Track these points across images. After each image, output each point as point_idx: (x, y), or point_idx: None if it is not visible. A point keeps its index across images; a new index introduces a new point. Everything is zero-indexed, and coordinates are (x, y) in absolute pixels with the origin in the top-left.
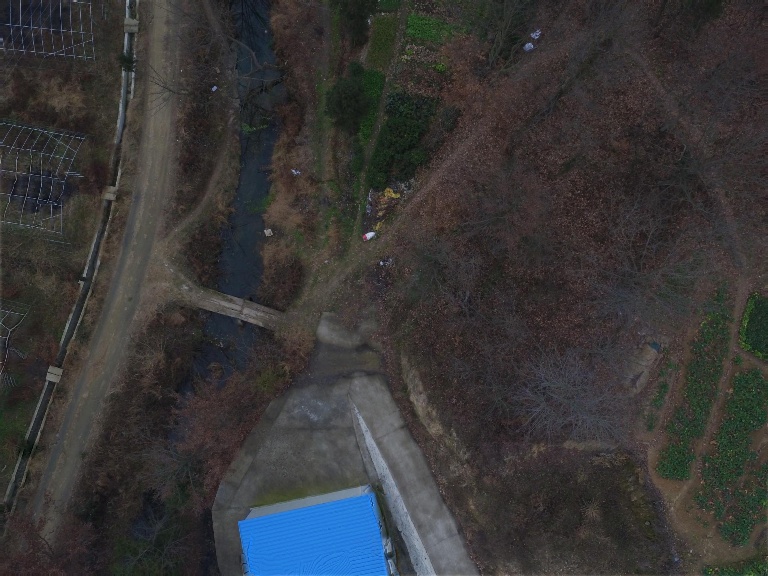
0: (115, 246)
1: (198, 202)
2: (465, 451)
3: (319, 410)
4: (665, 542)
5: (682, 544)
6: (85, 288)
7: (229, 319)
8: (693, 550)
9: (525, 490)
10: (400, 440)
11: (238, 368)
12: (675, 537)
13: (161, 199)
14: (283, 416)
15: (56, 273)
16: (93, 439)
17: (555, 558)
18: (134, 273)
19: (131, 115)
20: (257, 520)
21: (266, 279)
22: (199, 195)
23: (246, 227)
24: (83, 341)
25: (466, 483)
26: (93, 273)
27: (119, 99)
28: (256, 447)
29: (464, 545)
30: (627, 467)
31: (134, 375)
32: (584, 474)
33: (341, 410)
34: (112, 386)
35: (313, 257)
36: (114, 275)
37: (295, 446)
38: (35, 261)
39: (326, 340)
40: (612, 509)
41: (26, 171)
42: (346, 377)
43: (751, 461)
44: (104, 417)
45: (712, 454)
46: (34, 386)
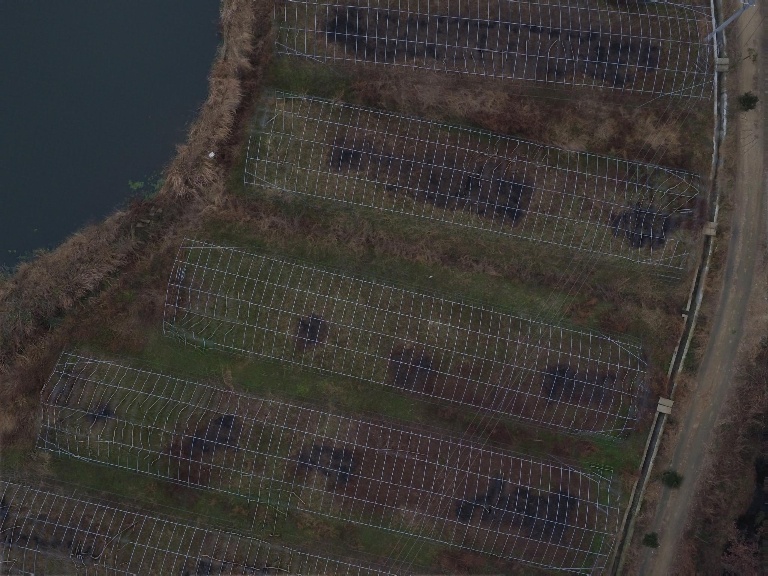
0: (718, 280)
1: None
2: None
3: None
4: None
5: None
6: (688, 321)
7: None
8: None
9: None
10: None
11: None
12: None
13: (758, 234)
14: None
15: (660, 307)
16: (707, 469)
17: None
18: (736, 307)
19: (725, 151)
20: None
21: None
22: None
23: None
24: (692, 373)
25: None
26: (695, 307)
27: (712, 136)
28: None
29: None
30: None
31: (744, 406)
32: None
33: None
34: (722, 417)
35: None
36: (718, 309)
37: None
38: (641, 295)
39: None
40: None
41: (637, 208)
42: None
43: None
44: (717, 447)
45: None
46: (645, 418)
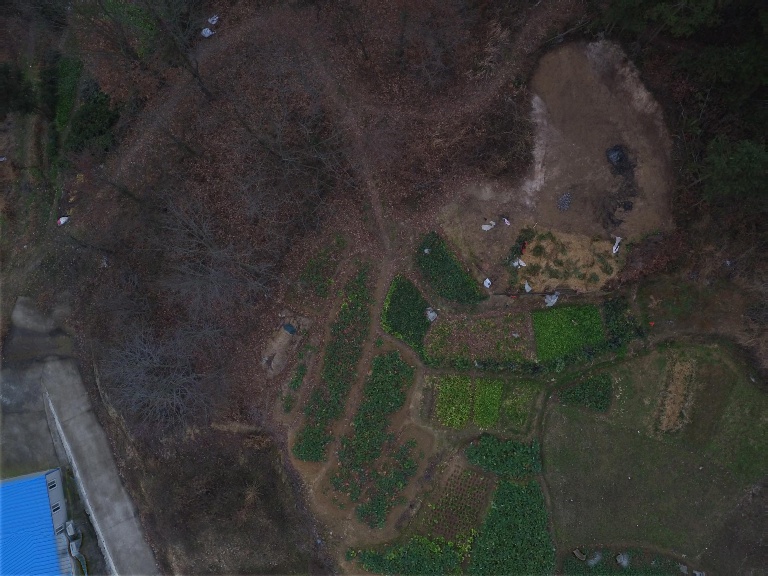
0: None
1: None
2: (130, 433)
3: (12, 394)
4: (308, 524)
5: (322, 526)
6: None
7: None
8: (333, 532)
9: (189, 472)
10: (85, 423)
11: None
12: (314, 519)
13: None
14: None
15: None
16: None
17: (218, 540)
18: None
19: None
20: None
21: None
22: None
23: None
24: None
25: (137, 466)
26: None
27: None
28: None
29: (139, 528)
30: (272, 449)
31: None
32: (244, 456)
33: (33, 394)
34: None
35: (13, 242)
36: None
37: None
38: None
39: (20, 324)
40: (271, 491)
41: None
42: (39, 361)
43: (392, 443)
44: None
45: (350, 435)
46: None
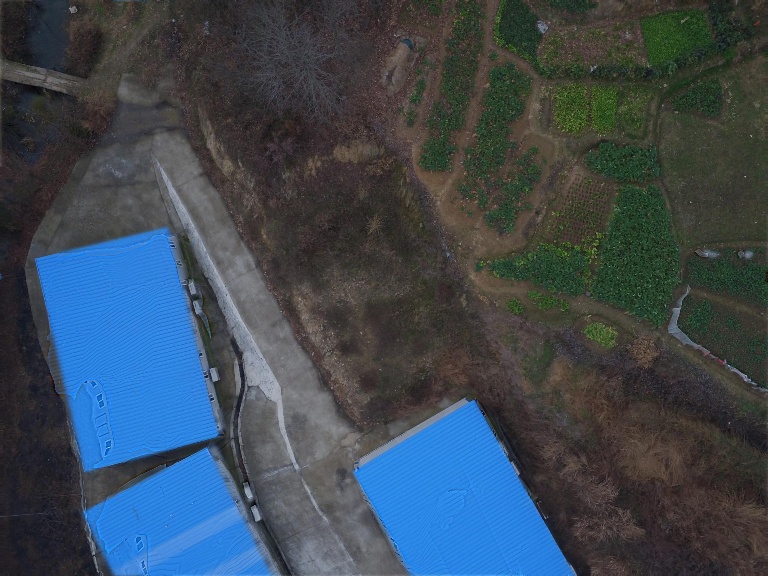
0: None
1: None
2: (250, 178)
3: (123, 167)
4: (436, 238)
5: (451, 237)
6: None
7: (35, 90)
8: (462, 242)
9: (311, 212)
10: (199, 186)
11: (50, 141)
12: (443, 230)
13: None
14: (88, 175)
15: None
16: None
17: (343, 276)
18: None
19: None
20: (55, 260)
21: (70, 50)
22: None
23: (52, 6)
24: None
25: (257, 214)
26: None
27: None
28: (64, 207)
29: (261, 277)
30: (396, 169)
31: None
32: (364, 190)
33: (144, 166)
34: None
35: (113, 24)
36: None
37: (101, 203)
38: None
39: (127, 100)
40: (393, 222)
41: None
42: (148, 134)
43: (514, 152)
44: None
45: (474, 146)
46: None
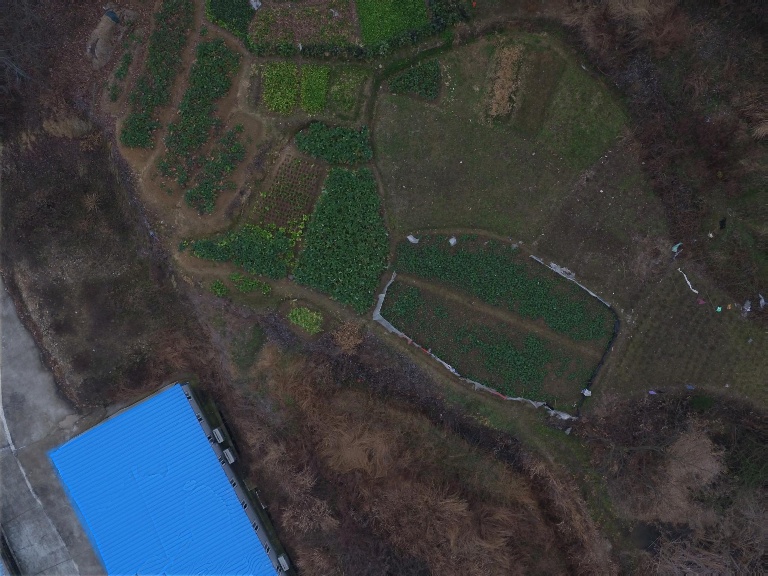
0: None
1: None
2: None
3: None
4: (140, 216)
5: (152, 215)
6: None
7: None
8: (164, 221)
9: (31, 188)
10: None
11: None
12: (144, 208)
13: None
14: None
15: None
16: None
17: (60, 253)
18: None
19: None
20: None
21: None
22: None
23: None
24: None
25: None
26: None
27: None
28: None
29: None
30: (103, 145)
31: None
32: (83, 166)
33: None
34: None
35: None
36: None
37: None
38: None
39: None
40: (110, 199)
41: None
42: None
43: (220, 130)
44: None
45: (177, 123)
46: None
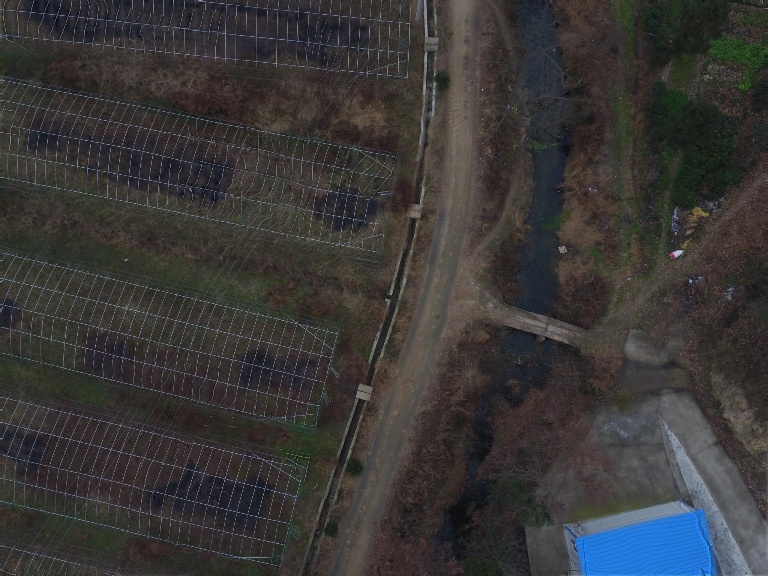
0: (422, 264)
1: (497, 219)
2: None
3: (629, 427)
4: None
5: None
6: (392, 306)
7: (532, 336)
8: None
9: None
10: (715, 456)
11: (536, 384)
12: None
13: (465, 217)
14: (593, 433)
15: (362, 291)
16: (406, 457)
17: None
18: (441, 291)
19: (433, 132)
20: (590, 537)
21: (567, 296)
22: (498, 212)
23: (540, 244)
24: (392, 359)
25: None
26: (399, 291)
27: (420, 116)
28: (567, 464)
29: None
30: None
31: (445, 393)
32: None
33: (651, 427)
34: (423, 404)
35: (615, 274)
36: (421, 293)
37: (606, 462)
38: (342, 279)
39: (634, 357)
40: None
41: (335, 189)
42: (655, 394)
43: None
44: (417, 435)
45: None
46: (344, 404)
